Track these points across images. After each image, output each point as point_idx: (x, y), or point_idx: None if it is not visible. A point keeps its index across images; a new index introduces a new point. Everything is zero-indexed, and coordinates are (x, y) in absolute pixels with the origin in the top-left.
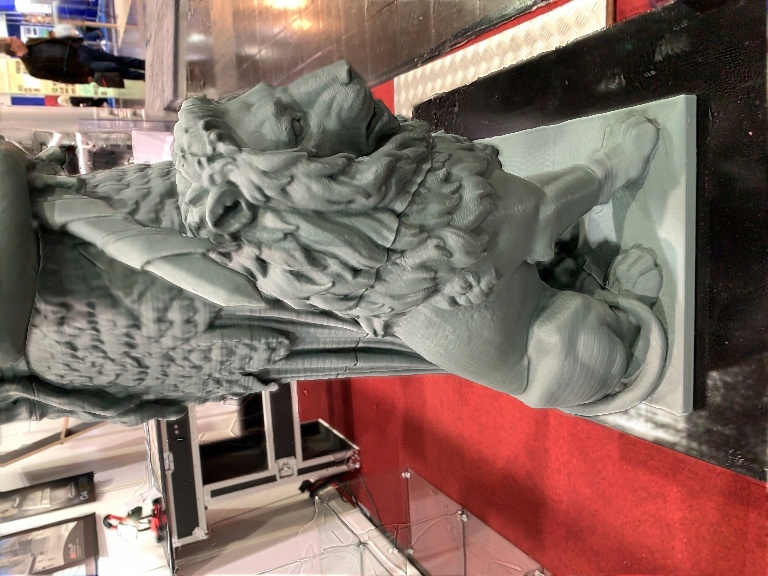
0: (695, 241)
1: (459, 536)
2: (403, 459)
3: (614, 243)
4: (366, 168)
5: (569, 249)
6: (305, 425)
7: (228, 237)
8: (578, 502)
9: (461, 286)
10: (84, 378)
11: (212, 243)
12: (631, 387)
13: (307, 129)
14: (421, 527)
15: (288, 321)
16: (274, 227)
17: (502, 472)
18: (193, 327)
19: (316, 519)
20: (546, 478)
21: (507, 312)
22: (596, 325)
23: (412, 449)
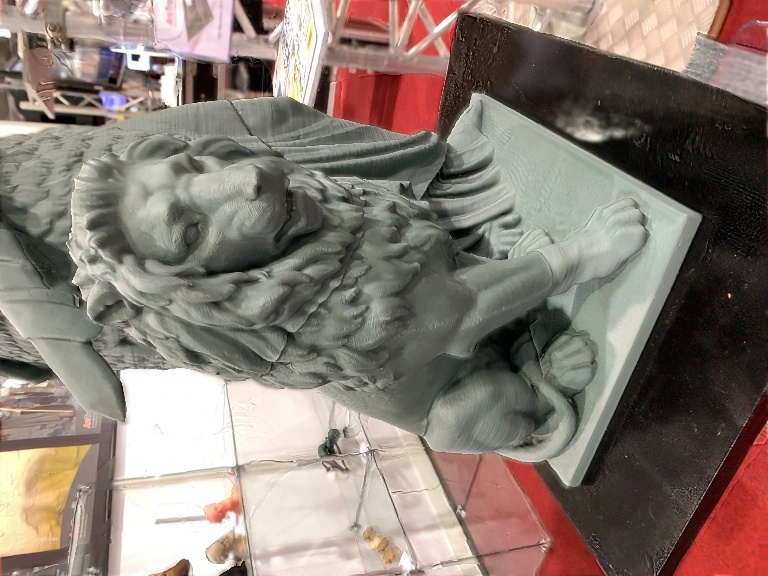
0: (640, 355)
1: None
2: None
3: (567, 317)
4: (255, 297)
5: None
6: None
7: None
8: None
9: (355, 384)
10: (6, 357)
11: (96, 326)
12: (531, 449)
13: (205, 235)
14: None
15: None
16: (156, 329)
17: None
18: (102, 344)
19: None
20: None
21: (408, 395)
22: (499, 415)
23: None
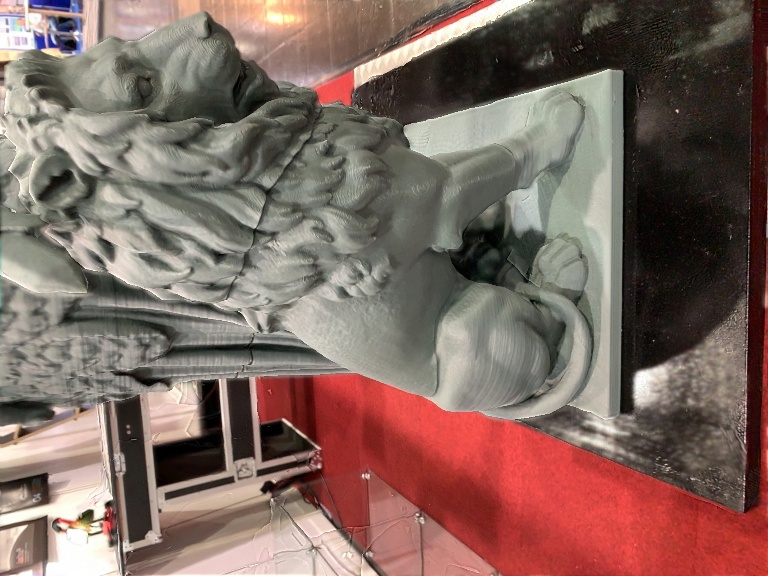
0: (622, 230)
1: (417, 539)
2: (363, 460)
3: (539, 232)
4: (224, 135)
5: (495, 239)
6: (268, 425)
7: (63, 214)
8: (532, 505)
9: (349, 275)
10: None
11: (40, 220)
12: (555, 388)
13: (158, 90)
14: (377, 530)
15: (163, 314)
16: (114, 202)
17: (459, 474)
18: (43, 320)
19: (271, 522)
20: (501, 480)
21: (408, 305)
22: (511, 320)
23: (372, 450)
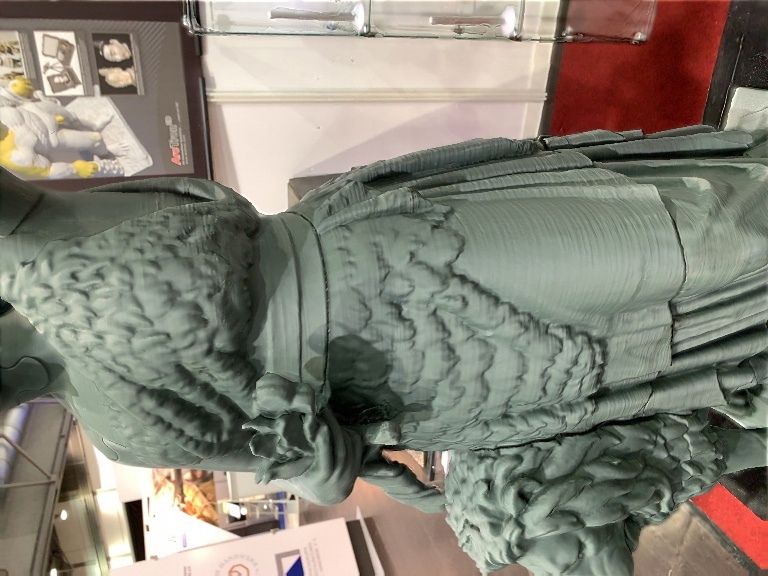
0: None
1: None
2: None
3: (759, 394)
4: None
5: None
6: None
7: None
8: None
9: None
10: None
11: None
12: None
13: None
14: None
15: None
16: None
17: None
18: None
19: None
20: None
21: None
22: None
23: None
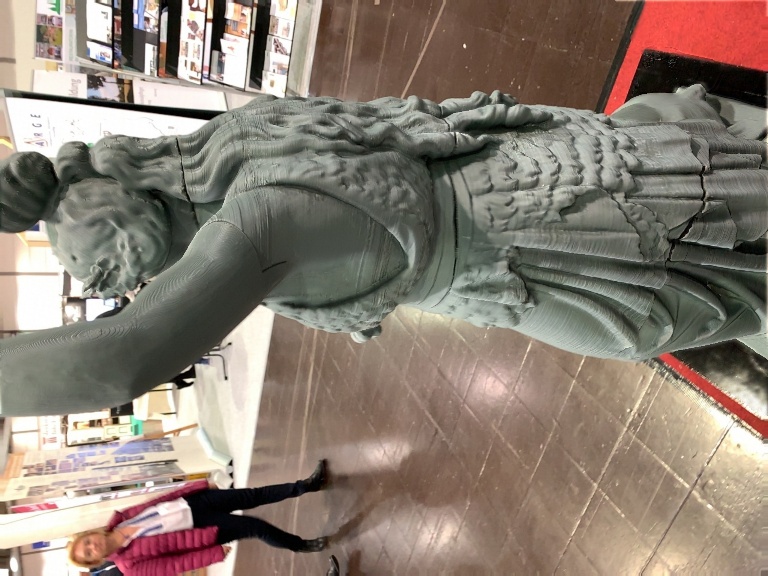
0: None
1: None
2: None
3: None
4: None
5: None
6: None
7: None
8: None
9: None
10: None
11: None
12: None
13: None
14: None
15: None
16: None
17: None
18: None
19: None
20: None
21: None
22: None
23: None
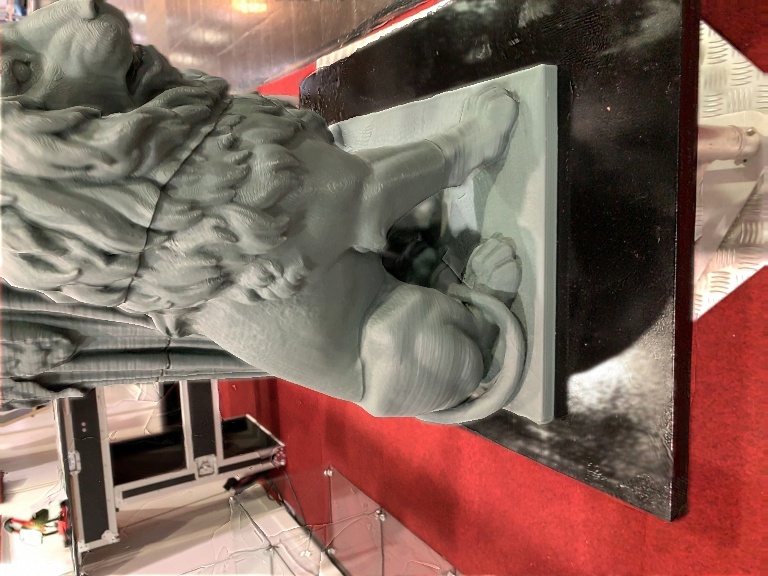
0: (556, 230)
1: (377, 536)
2: (326, 456)
3: (475, 232)
4: (109, 126)
5: (431, 238)
6: (233, 421)
7: None
8: (488, 502)
9: (259, 277)
10: None
11: None
12: (488, 393)
13: (39, 75)
14: (337, 528)
15: (65, 316)
16: None
17: (418, 471)
18: None
19: (231, 520)
20: (459, 477)
21: (328, 308)
22: (438, 324)
23: (334, 446)
